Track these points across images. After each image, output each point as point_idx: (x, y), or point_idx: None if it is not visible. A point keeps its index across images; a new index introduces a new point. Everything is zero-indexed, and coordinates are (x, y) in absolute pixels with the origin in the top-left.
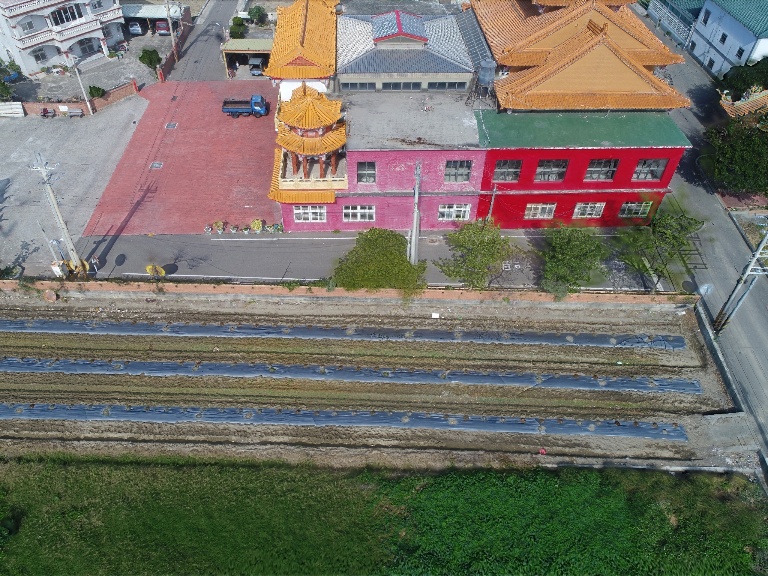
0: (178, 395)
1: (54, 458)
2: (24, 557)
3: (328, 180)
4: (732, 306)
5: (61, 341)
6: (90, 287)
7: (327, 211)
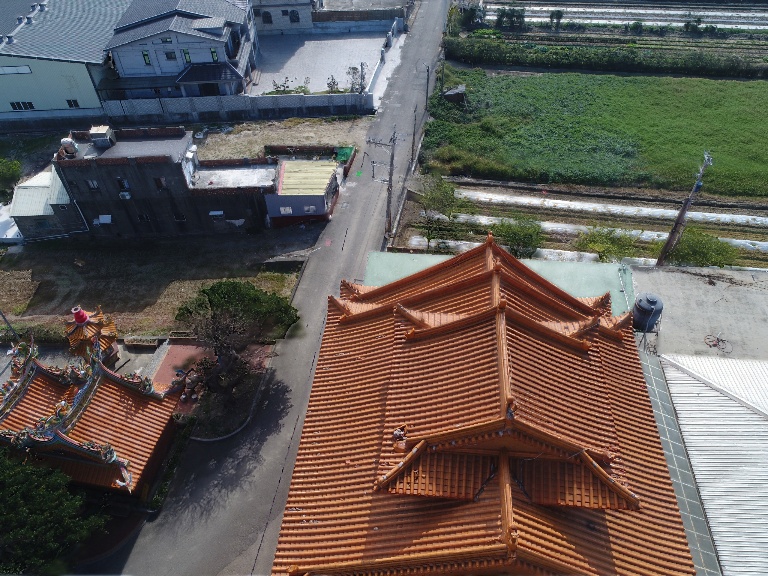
0: None
1: None
2: None
3: None
4: (360, 247)
5: None
6: None
7: None
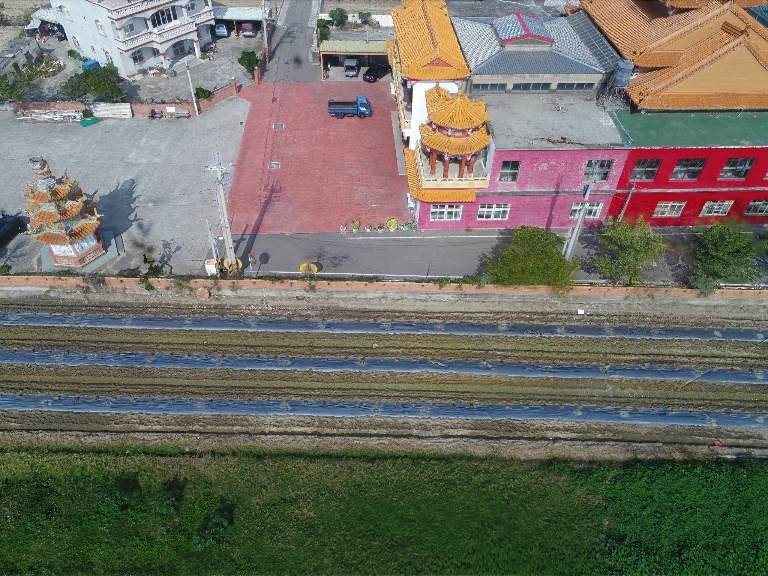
0: (350, 390)
1: (247, 452)
2: (247, 547)
3: (470, 179)
4: None
5: (222, 338)
6: (243, 285)
7: (463, 210)
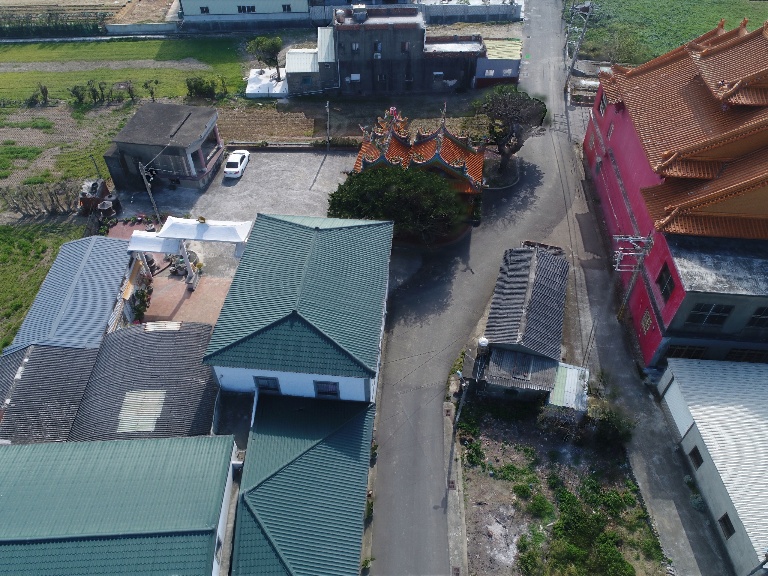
0: None
1: None
2: None
3: None
4: (549, 97)
5: None
6: None
7: None
